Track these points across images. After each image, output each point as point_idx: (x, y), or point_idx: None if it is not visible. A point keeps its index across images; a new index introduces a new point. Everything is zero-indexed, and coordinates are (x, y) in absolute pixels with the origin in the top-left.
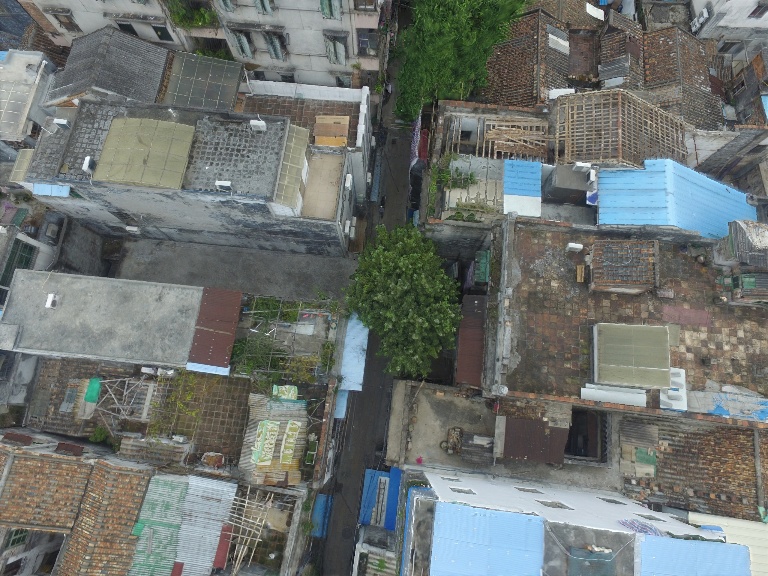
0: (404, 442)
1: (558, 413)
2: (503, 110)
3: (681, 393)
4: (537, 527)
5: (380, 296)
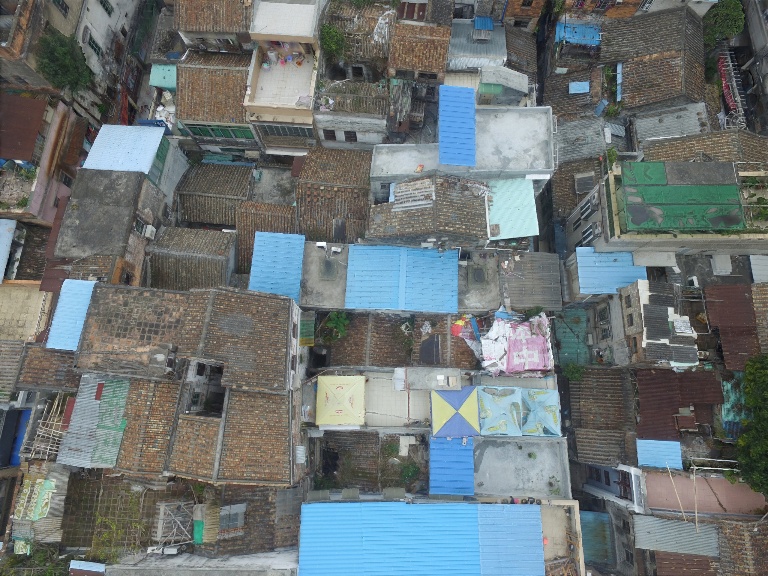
0: None
1: None
2: None
3: None
4: None
5: None
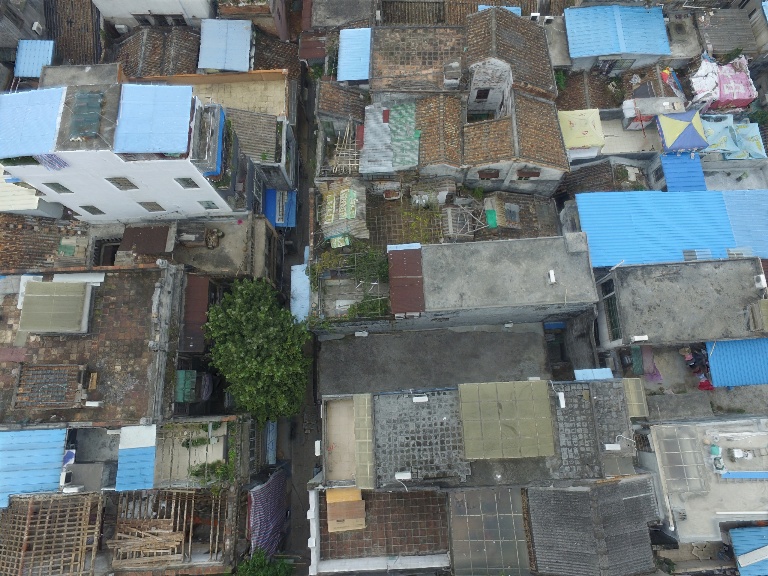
0: (249, 229)
1: (125, 261)
2: (159, 570)
3: (24, 289)
4: (118, 147)
5: (271, 330)
